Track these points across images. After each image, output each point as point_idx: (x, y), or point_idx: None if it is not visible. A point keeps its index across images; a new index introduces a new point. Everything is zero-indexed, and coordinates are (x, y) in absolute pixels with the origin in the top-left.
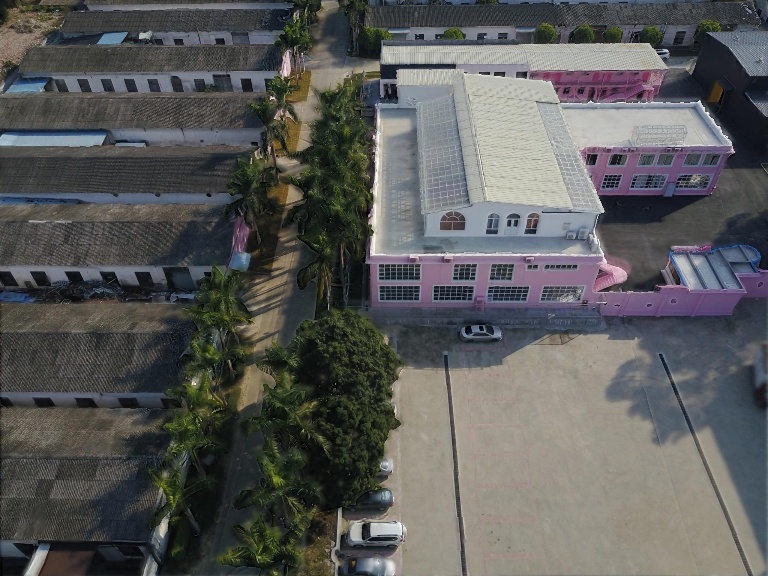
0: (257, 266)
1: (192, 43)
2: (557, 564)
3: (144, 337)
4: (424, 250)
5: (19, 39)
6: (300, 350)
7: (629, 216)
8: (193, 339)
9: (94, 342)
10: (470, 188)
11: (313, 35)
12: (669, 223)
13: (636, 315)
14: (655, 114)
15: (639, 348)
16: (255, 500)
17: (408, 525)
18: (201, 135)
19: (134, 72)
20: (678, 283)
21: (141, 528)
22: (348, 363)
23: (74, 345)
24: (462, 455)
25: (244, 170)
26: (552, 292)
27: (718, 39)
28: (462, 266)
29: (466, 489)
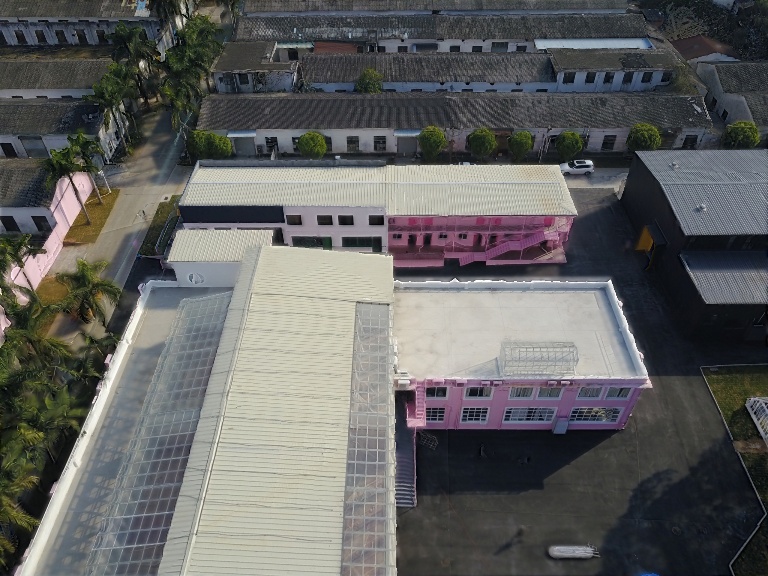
0: None
1: None
2: None
3: None
4: None
5: None
6: None
7: (496, 475)
8: None
9: None
10: (171, 534)
11: (144, 130)
12: (554, 491)
13: None
14: (545, 302)
15: None
16: None
17: None
18: None
19: None
20: None
21: None
22: None
23: None
24: None
25: None
26: None
27: (648, 166)
28: None
29: None
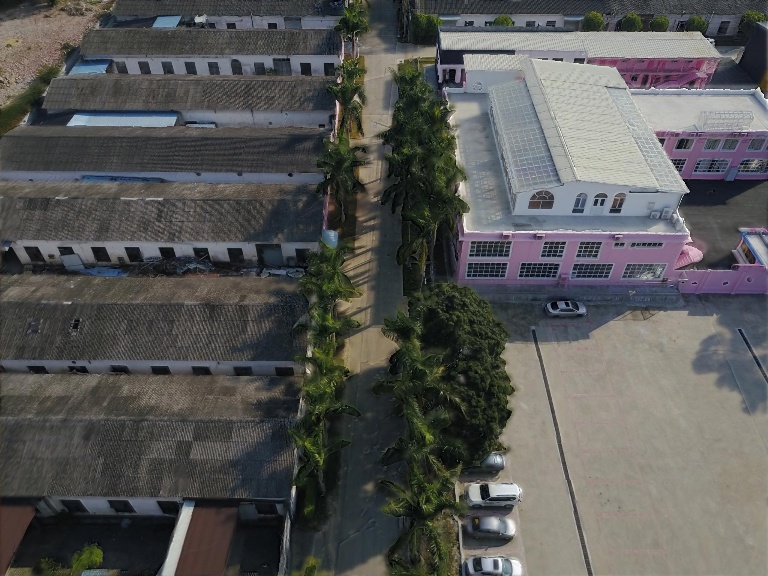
0: (340, 244)
1: (244, 27)
2: (667, 522)
3: (256, 308)
4: (514, 228)
5: (72, 22)
6: (423, 319)
7: (694, 199)
8: (311, 309)
9: (208, 313)
10: (559, 168)
11: None
12: (734, 206)
13: (712, 293)
14: (716, 100)
15: (718, 324)
16: (410, 455)
17: (520, 487)
18: (270, 117)
19: (195, 55)
20: (752, 262)
21: (281, 486)
22: (470, 331)
23: (189, 316)
24: (562, 423)
25: (337, 149)
26: (634, 270)
27: None
28: (551, 243)
29: (570, 454)
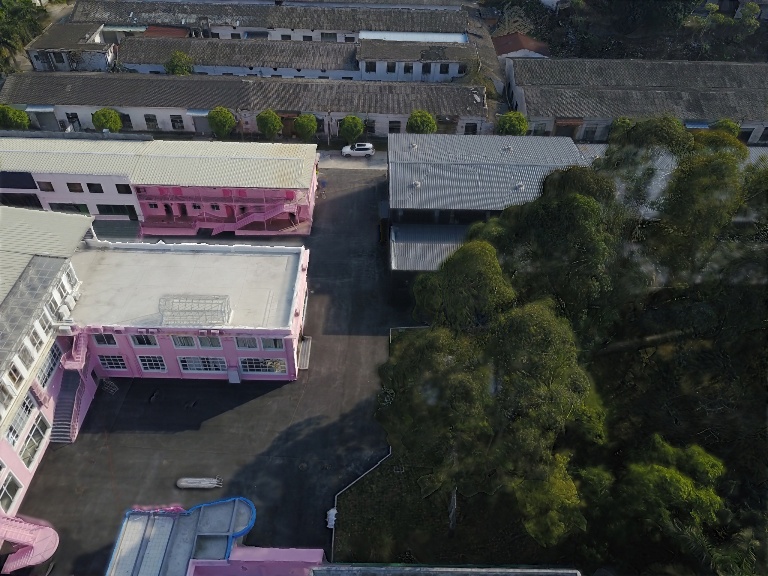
0: None
1: None
2: None
3: None
4: None
5: None
6: None
7: (161, 417)
8: None
9: None
10: None
11: None
12: (207, 432)
13: None
14: (238, 264)
15: None
16: None
17: None
18: None
19: None
20: None
21: None
22: None
23: None
24: None
25: None
26: None
27: (389, 146)
28: None
29: None
